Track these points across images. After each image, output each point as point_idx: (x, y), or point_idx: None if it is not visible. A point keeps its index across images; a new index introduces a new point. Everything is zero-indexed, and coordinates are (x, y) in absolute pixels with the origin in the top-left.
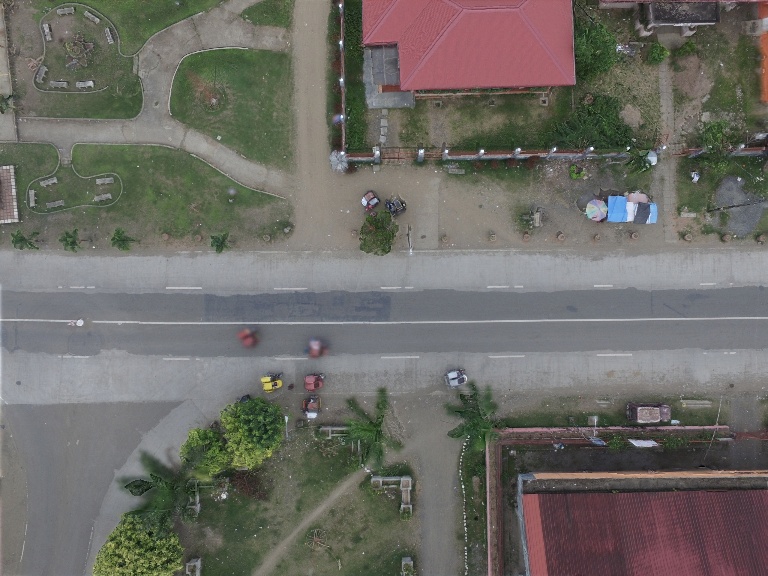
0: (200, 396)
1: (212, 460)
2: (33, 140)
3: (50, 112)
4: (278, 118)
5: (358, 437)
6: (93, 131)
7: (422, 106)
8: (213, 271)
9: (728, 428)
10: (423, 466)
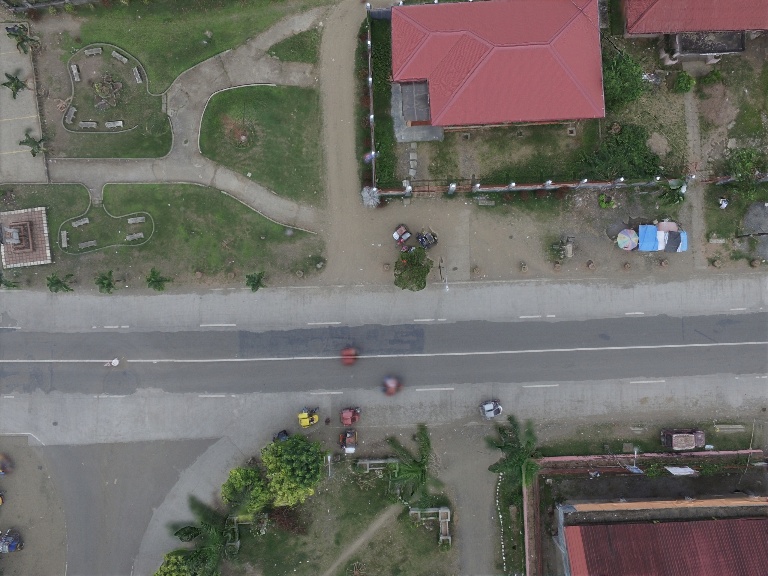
0: (237, 433)
1: (255, 500)
2: (64, 181)
3: (80, 152)
4: (308, 154)
5: (404, 478)
6: (123, 170)
7: (451, 139)
8: (246, 308)
9: (762, 452)
10: (460, 497)
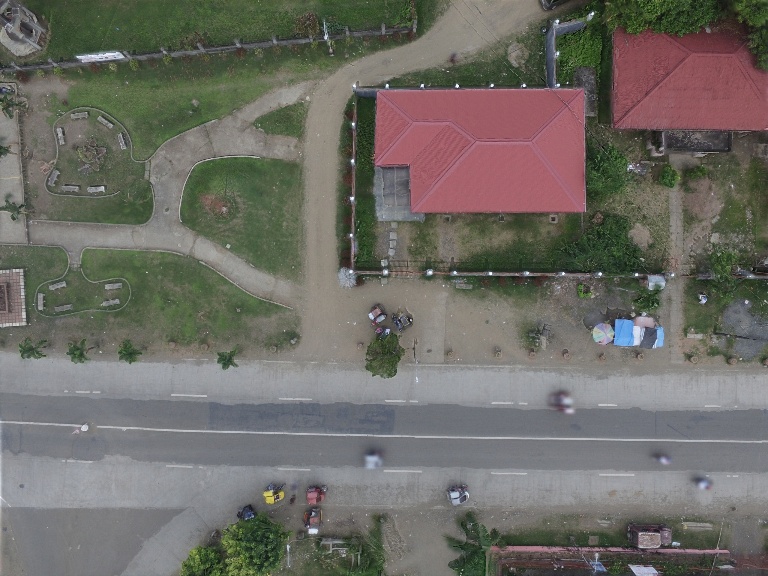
0: (202, 504)
1: None
2: (43, 243)
3: (61, 215)
4: (288, 228)
5: None
6: (103, 235)
7: (432, 220)
8: (219, 379)
9: (729, 554)
10: None
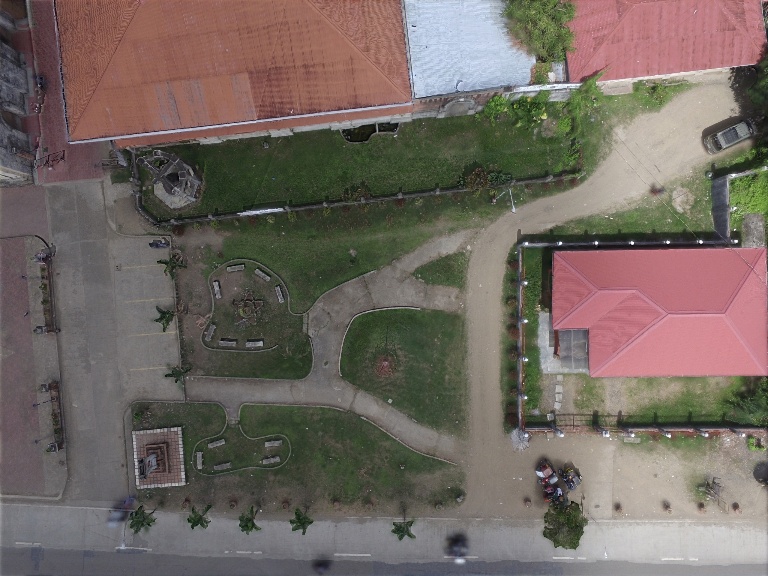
0: None
1: None
2: (200, 399)
3: (218, 371)
4: (450, 381)
5: None
6: (261, 391)
7: None
8: (382, 538)
9: None
10: None
